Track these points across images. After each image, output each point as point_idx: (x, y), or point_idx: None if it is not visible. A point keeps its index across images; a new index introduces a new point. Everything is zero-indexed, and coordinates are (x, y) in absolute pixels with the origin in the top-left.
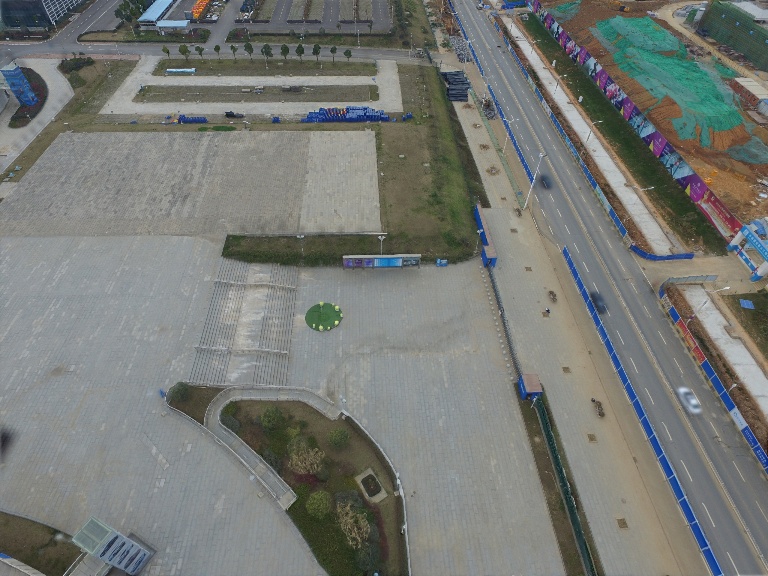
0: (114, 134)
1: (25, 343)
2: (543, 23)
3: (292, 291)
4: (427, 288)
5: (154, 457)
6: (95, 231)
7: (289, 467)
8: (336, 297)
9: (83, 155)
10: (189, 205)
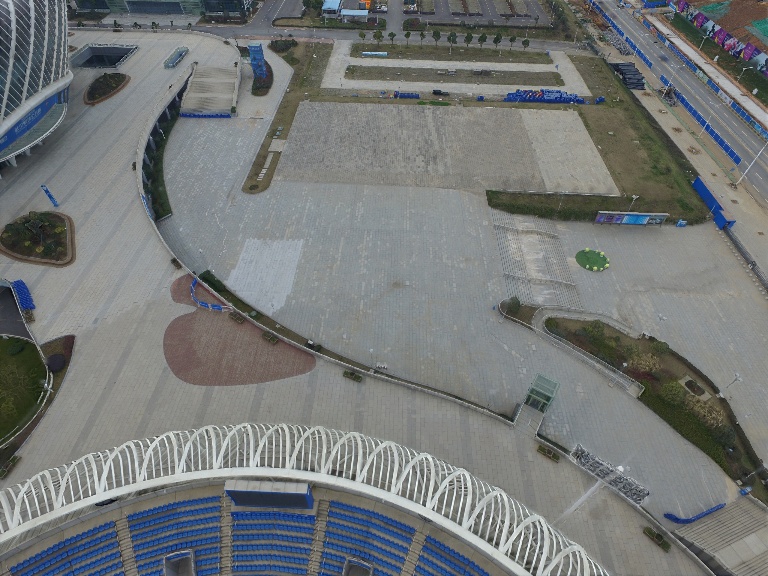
0: (347, 104)
1: (360, 262)
2: (692, 22)
3: (556, 239)
4: (674, 243)
5: (508, 352)
6: (372, 181)
7: (627, 367)
8: (596, 246)
9: (329, 120)
10: (441, 164)
